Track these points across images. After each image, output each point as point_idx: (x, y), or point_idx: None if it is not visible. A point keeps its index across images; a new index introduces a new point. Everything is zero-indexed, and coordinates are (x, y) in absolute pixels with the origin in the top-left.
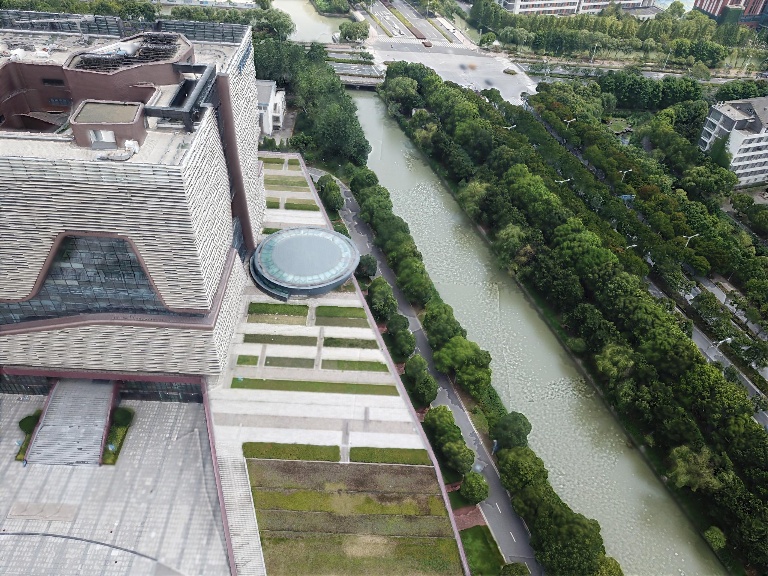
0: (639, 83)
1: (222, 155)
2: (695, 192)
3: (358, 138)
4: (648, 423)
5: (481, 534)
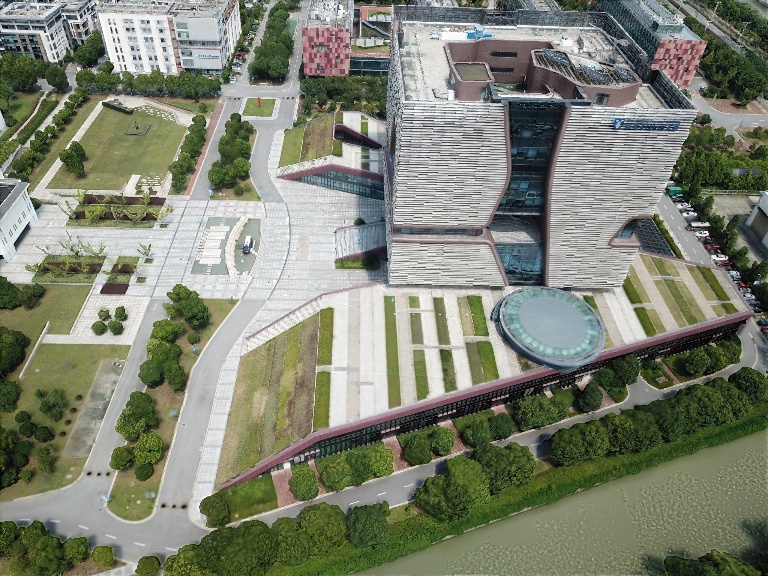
0: None
1: (503, 152)
2: None
3: None
4: None
5: (267, 498)
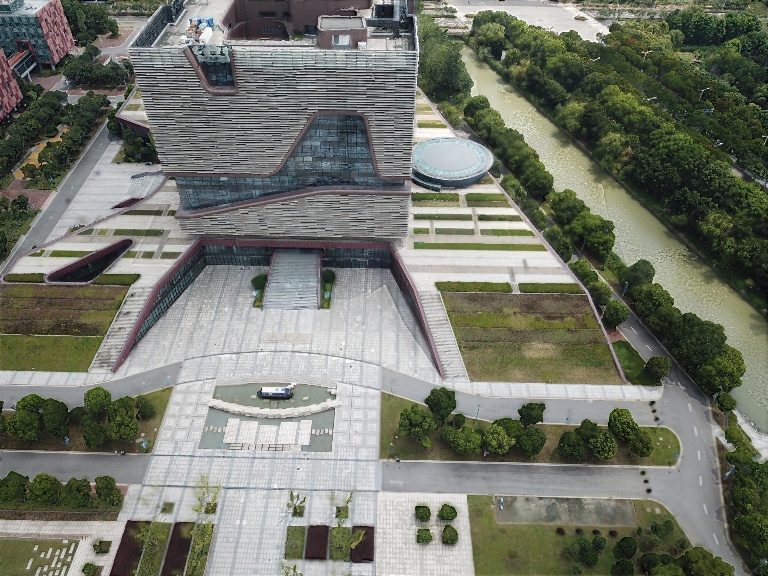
0: (704, 19)
1: None
2: (765, 107)
3: (463, 74)
4: (748, 271)
5: (625, 345)
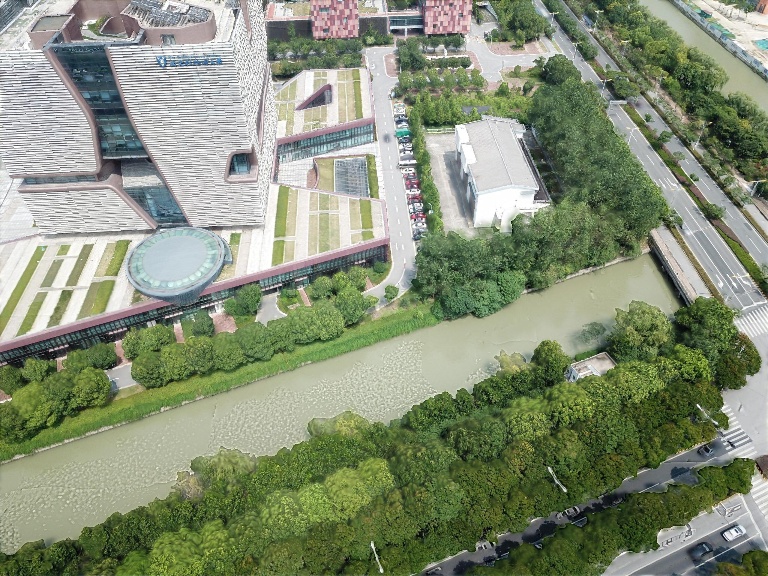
0: None
1: (70, 97)
2: None
3: None
4: None
5: None
